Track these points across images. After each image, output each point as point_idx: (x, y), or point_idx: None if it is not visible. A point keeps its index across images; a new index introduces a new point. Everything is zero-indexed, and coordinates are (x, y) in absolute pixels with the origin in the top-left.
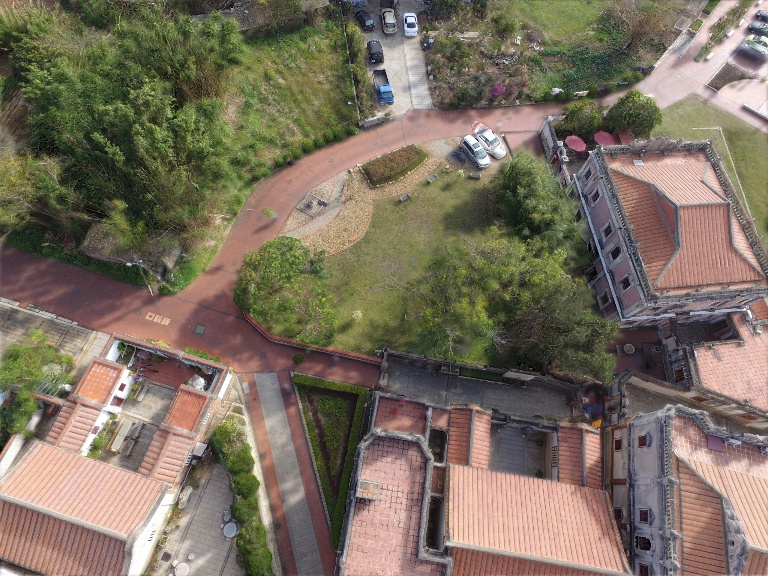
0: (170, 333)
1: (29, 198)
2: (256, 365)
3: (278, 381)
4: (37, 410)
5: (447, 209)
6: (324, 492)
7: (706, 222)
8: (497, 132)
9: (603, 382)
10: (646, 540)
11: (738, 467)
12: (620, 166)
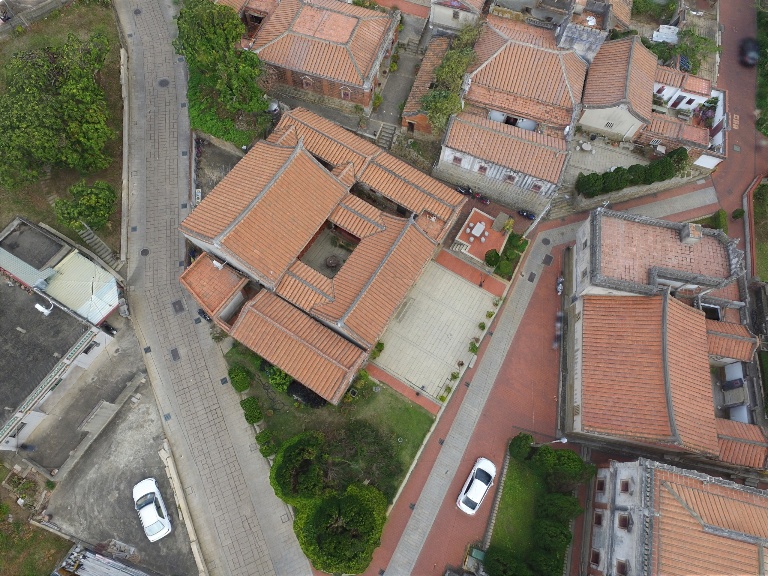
0: None
1: None
2: (720, 187)
3: (712, 203)
4: (663, 61)
5: None
6: None
7: None
8: None
9: None
10: None
11: None
12: None
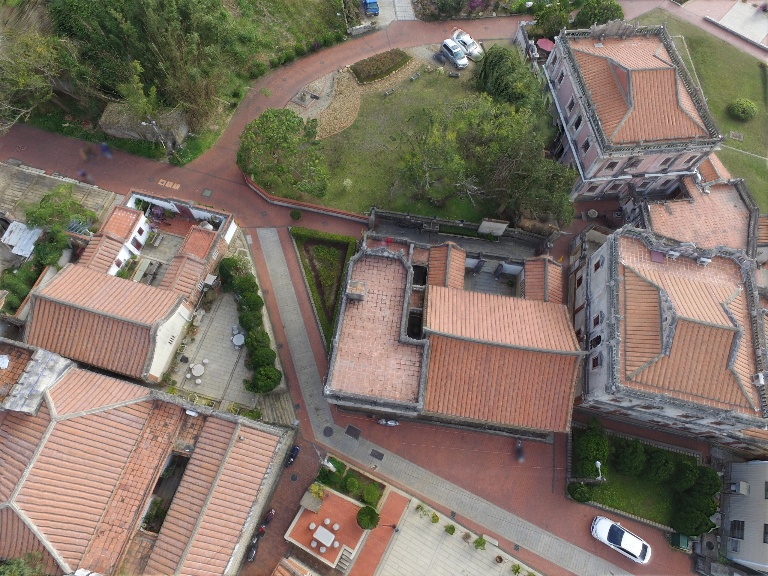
0: (180, 196)
1: (52, 72)
2: (258, 222)
3: (278, 235)
4: (67, 249)
5: (429, 102)
6: (320, 320)
7: (655, 85)
8: (475, 39)
9: (569, 240)
10: (598, 337)
11: (676, 274)
12: (582, 48)
